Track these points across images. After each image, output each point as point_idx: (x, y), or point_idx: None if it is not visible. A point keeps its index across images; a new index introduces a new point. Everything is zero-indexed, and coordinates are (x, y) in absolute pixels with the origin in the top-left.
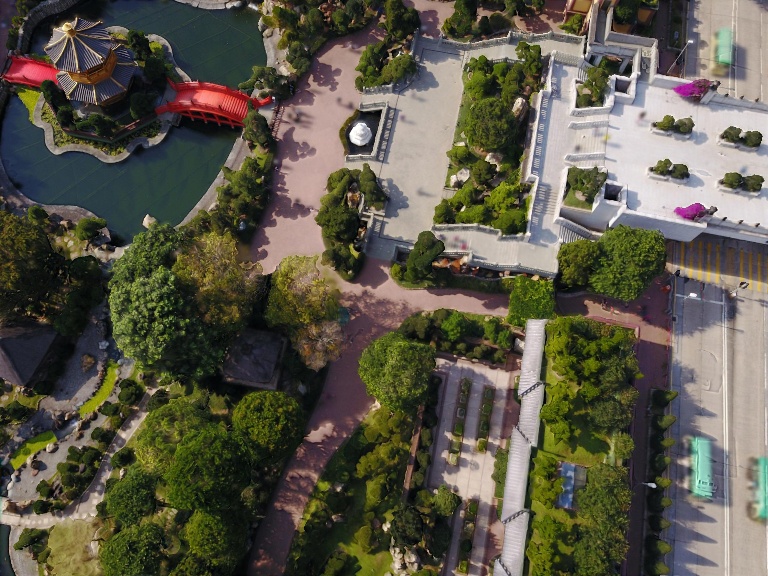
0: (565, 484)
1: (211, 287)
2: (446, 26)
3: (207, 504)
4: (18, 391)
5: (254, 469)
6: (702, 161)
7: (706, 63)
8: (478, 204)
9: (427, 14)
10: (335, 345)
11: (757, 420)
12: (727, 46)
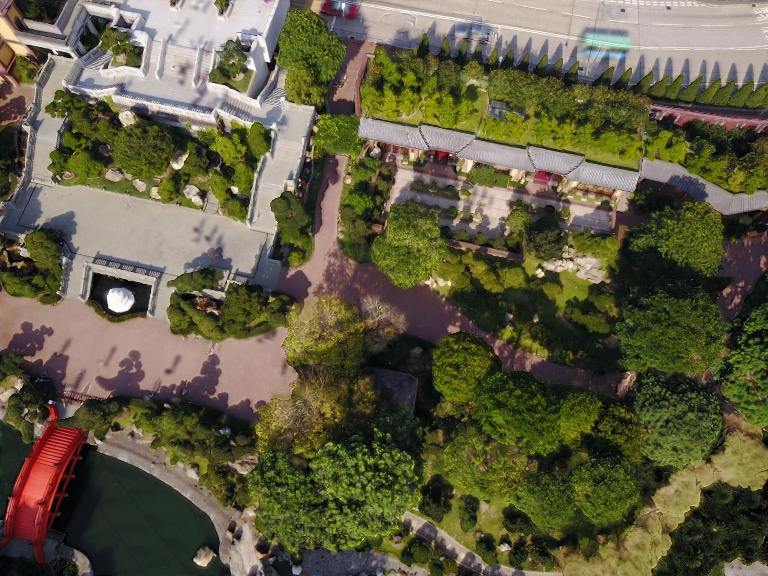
0: None
1: (336, 408)
2: None
3: None
4: None
5: None
6: None
7: None
8: (228, 178)
9: None
10: None
11: None
12: None
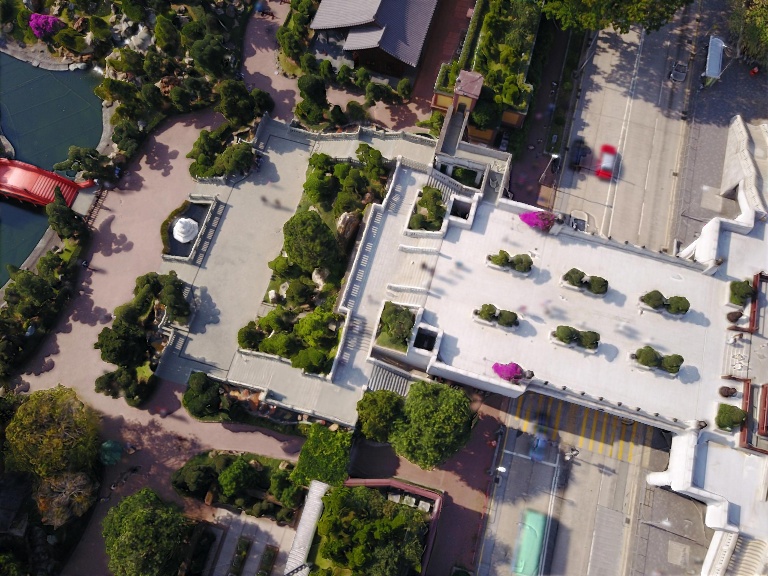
0: None
1: None
2: (297, 112)
3: None
4: None
5: None
6: (539, 305)
7: (585, 173)
8: None
9: (284, 94)
10: (84, 497)
11: None
12: (612, 154)
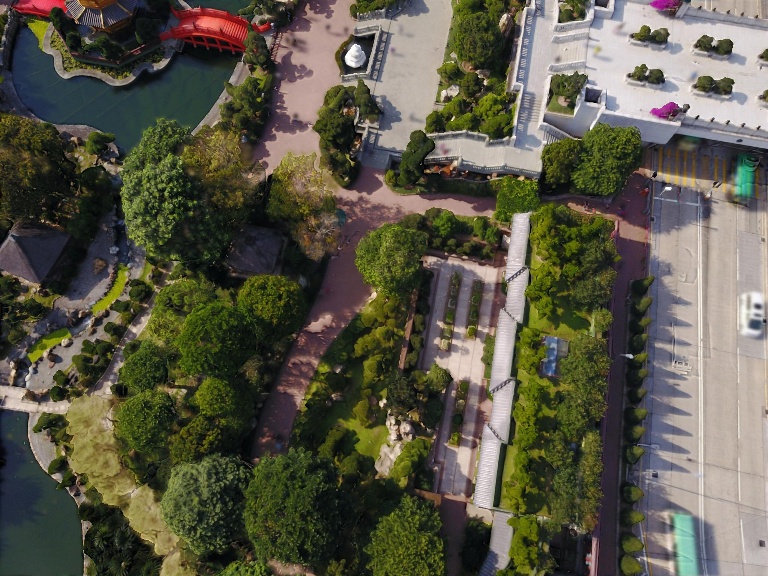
0: (548, 355)
1: (217, 173)
2: None
3: (216, 367)
4: (34, 292)
5: (258, 354)
6: (677, 69)
7: None
8: None
9: None
10: (333, 238)
11: (730, 308)
12: None
